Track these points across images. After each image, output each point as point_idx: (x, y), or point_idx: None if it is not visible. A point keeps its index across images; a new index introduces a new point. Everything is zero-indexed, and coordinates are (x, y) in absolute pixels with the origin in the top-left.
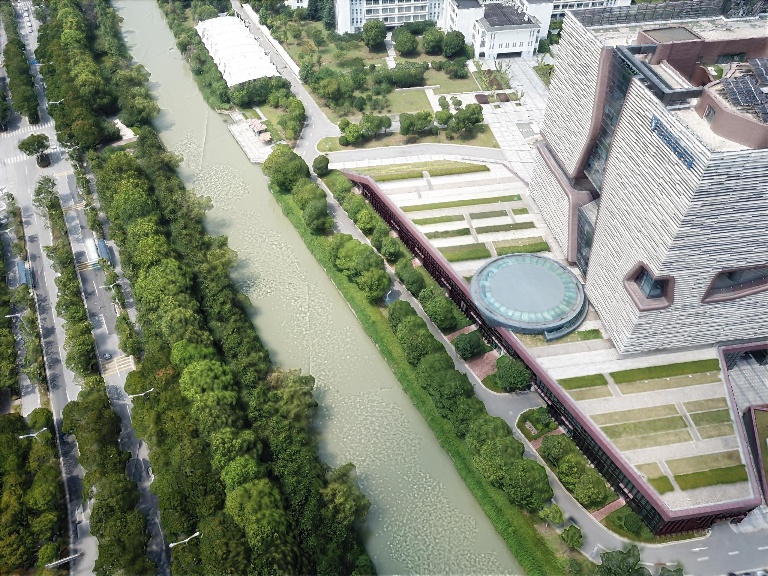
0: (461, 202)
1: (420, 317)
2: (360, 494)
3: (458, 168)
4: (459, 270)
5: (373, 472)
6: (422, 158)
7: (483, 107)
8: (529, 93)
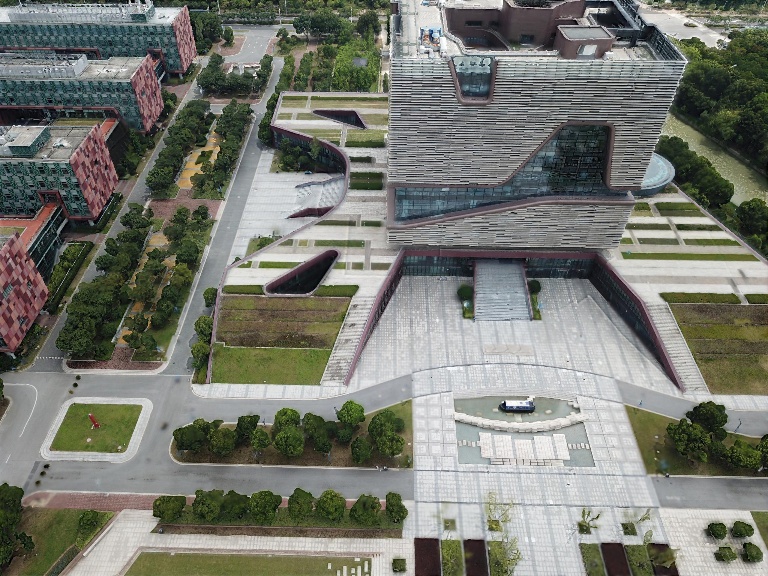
0: (690, 257)
1: (707, 179)
2: (717, 120)
3: (702, 300)
4: (682, 198)
5: (707, 155)
6: (750, 402)
7: (659, 532)
8: (556, 571)
